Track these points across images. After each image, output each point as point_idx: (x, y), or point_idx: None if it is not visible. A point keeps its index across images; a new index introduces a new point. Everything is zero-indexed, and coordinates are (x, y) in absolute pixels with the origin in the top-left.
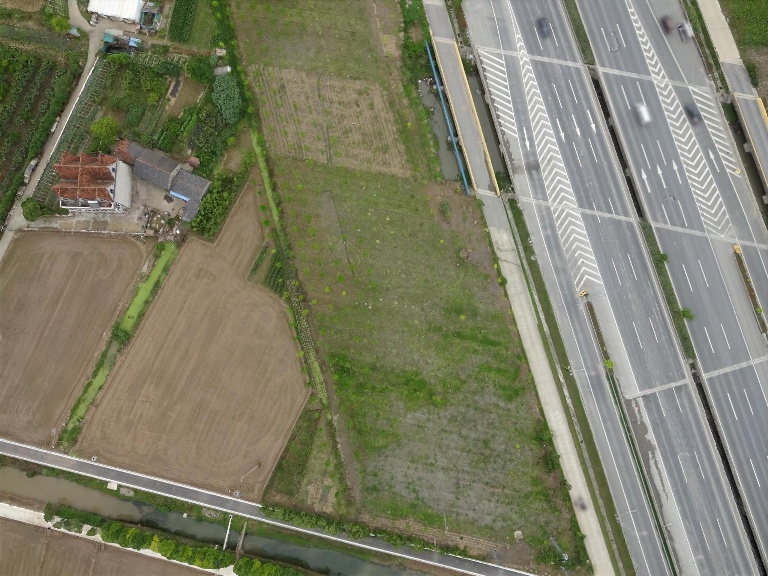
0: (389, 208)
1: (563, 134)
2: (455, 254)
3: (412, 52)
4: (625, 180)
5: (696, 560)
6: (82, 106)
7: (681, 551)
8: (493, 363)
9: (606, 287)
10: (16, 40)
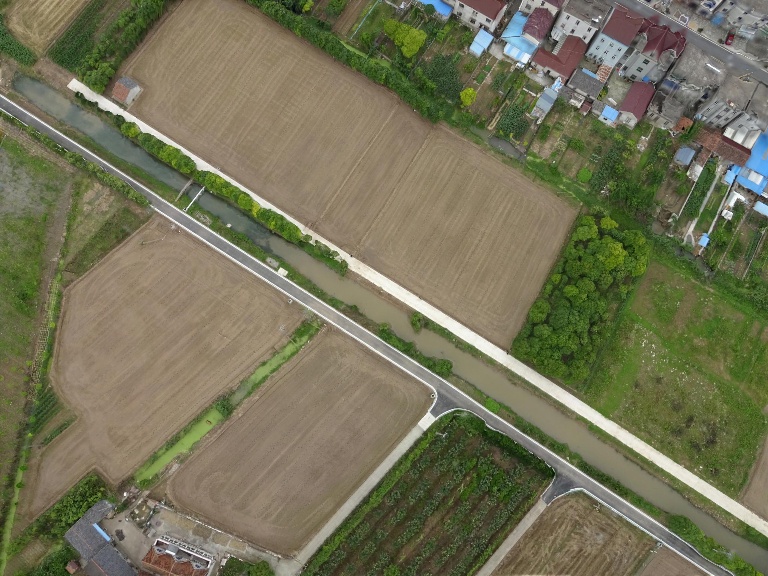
0: None
1: None
2: None
3: None
4: None
5: None
6: None
7: None
8: None
9: None
10: None
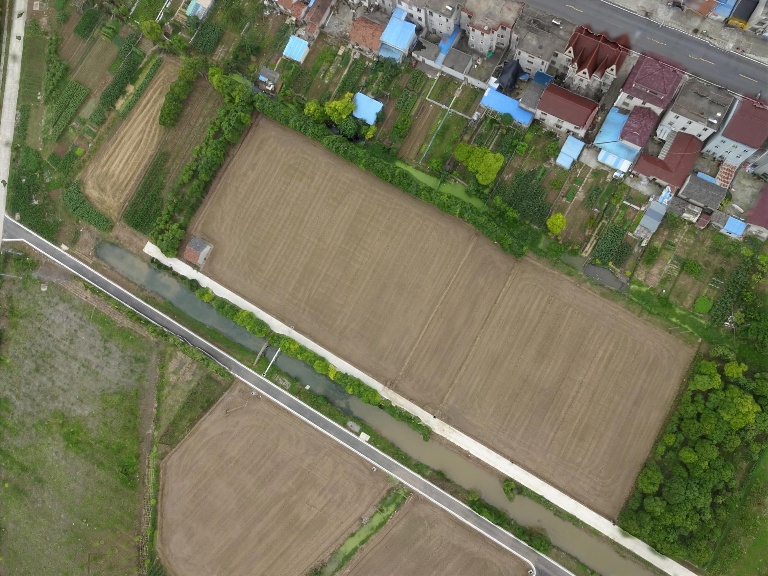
0: None
1: None
2: (2, 541)
3: None
4: None
5: None
6: None
7: None
8: (7, 434)
9: None
10: None
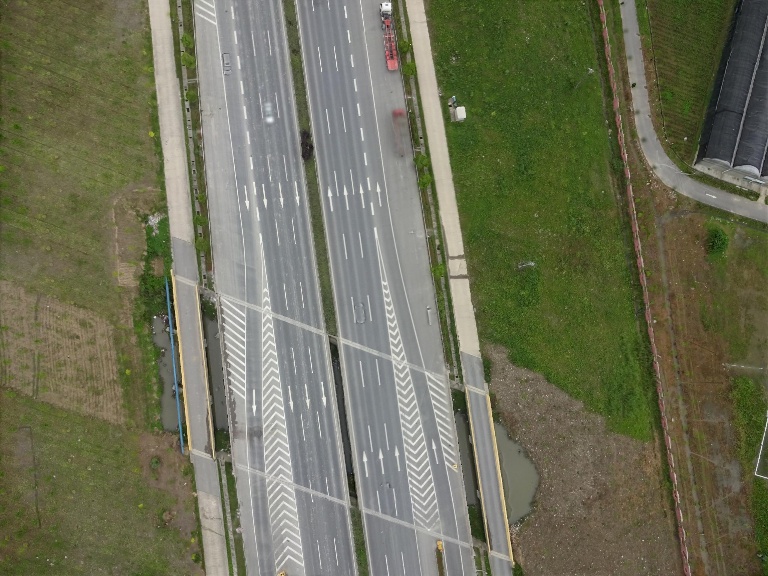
0: (93, 457)
1: (292, 403)
2: (157, 515)
3: (149, 287)
4: (344, 463)
5: None
6: None
7: None
8: None
9: (306, 570)
10: None
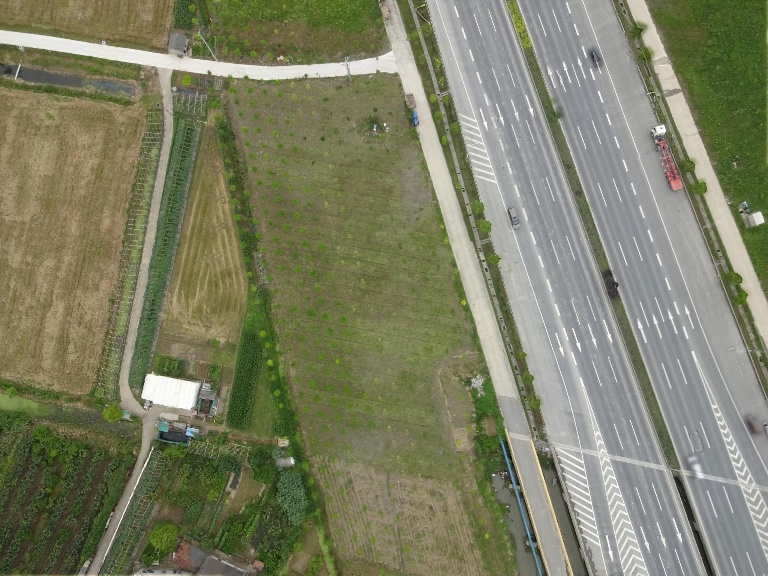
0: None
1: (648, 544)
2: None
3: (486, 448)
4: None
5: None
6: (138, 504)
7: None
8: None
9: None
10: (65, 426)
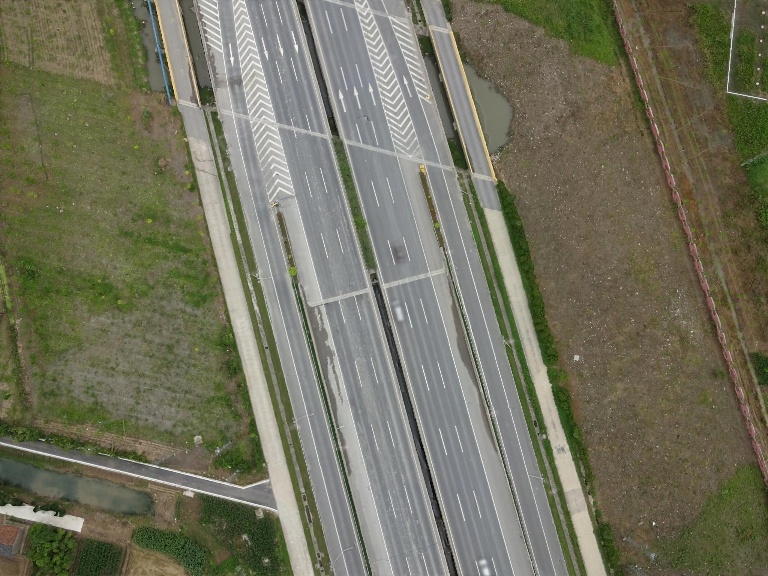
0: (89, 114)
1: (267, 52)
2: (153, 162)
3: None
4: (321, 98)
5: (365, 461)
6: None
7: (352, 452)
8: (183, 269)
9: (298, 199)
10: None
